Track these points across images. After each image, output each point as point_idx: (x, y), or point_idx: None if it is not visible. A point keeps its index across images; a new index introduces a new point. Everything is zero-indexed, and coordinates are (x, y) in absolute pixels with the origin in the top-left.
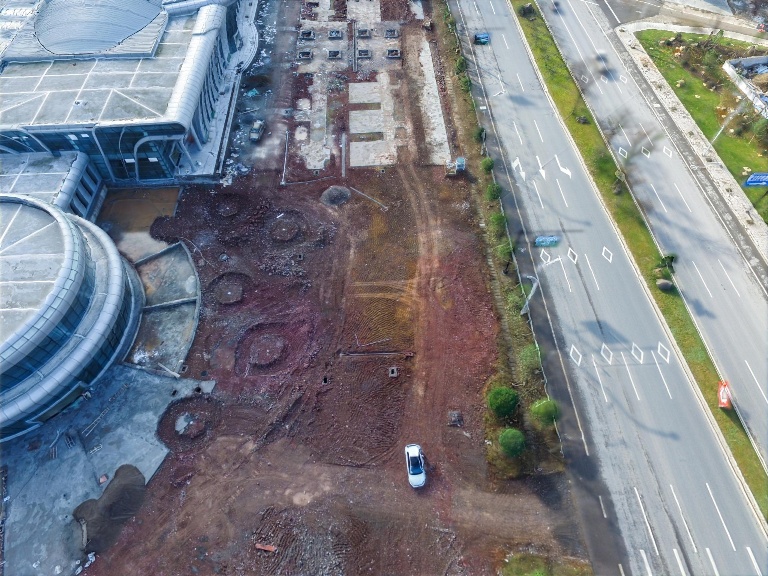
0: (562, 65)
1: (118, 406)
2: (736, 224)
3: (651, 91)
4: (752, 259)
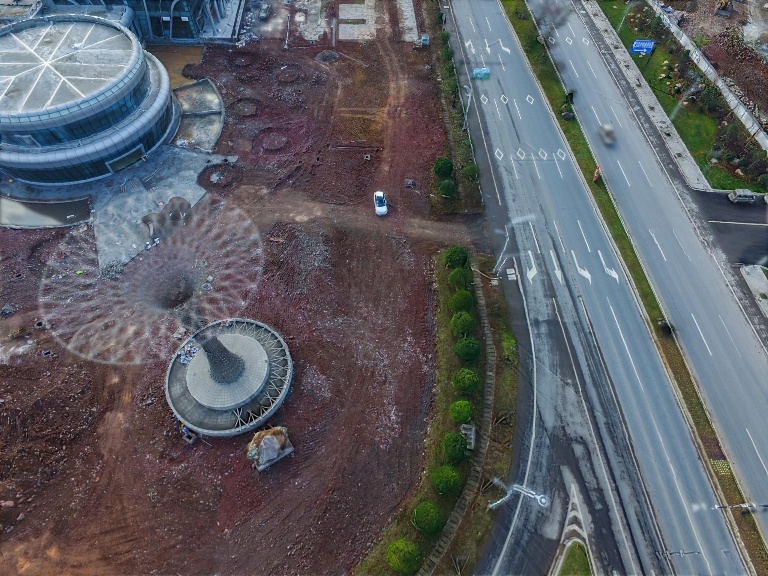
0: None
1: (168, 167)
2: (628, 86)
3: (580, 2)
4: (635, 107)
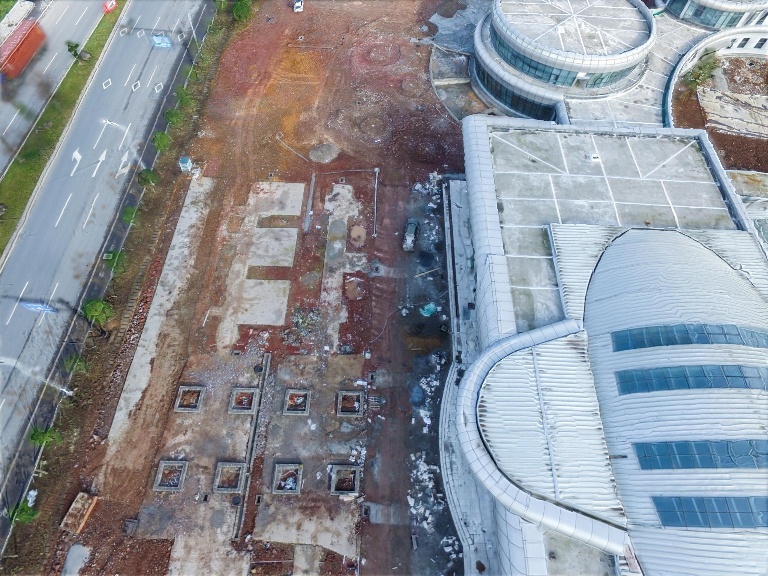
0: None
1: None
2: None
3: None
4: None
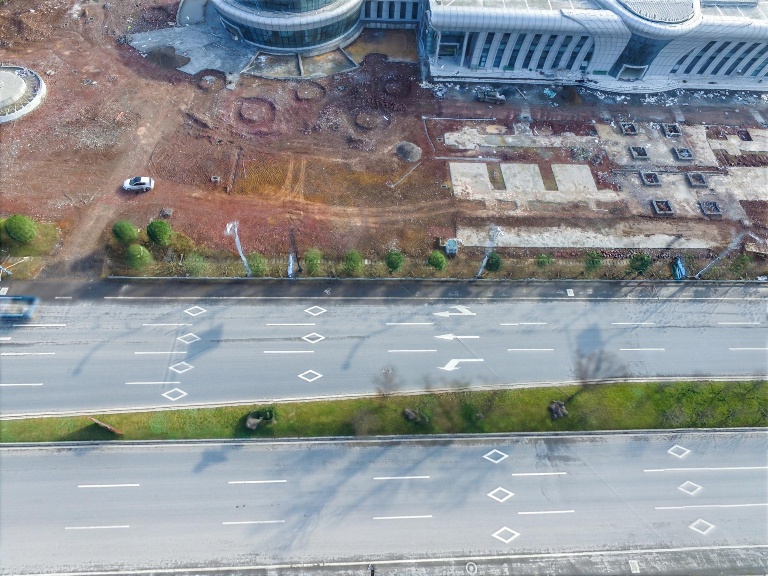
0: (702, 416)
1: (229, 53)
2: None
3: (678, 571)
4: None
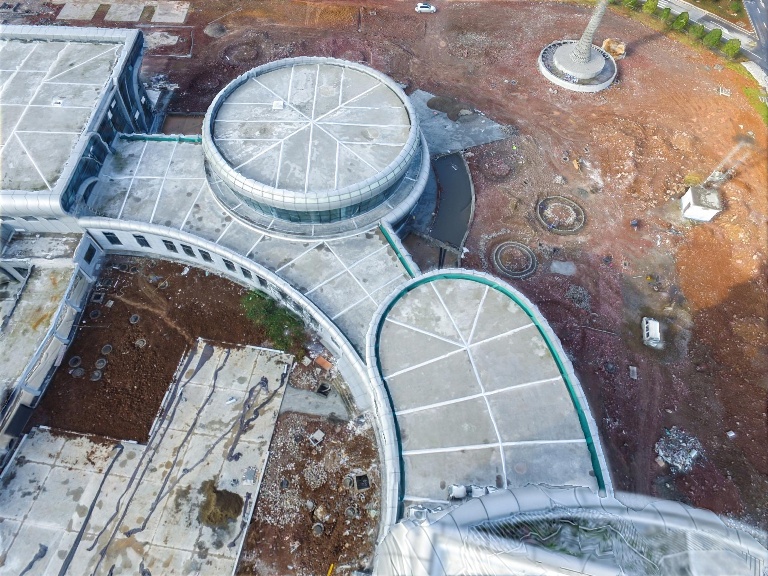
0: None
1: None
2: None
3: None
4: None
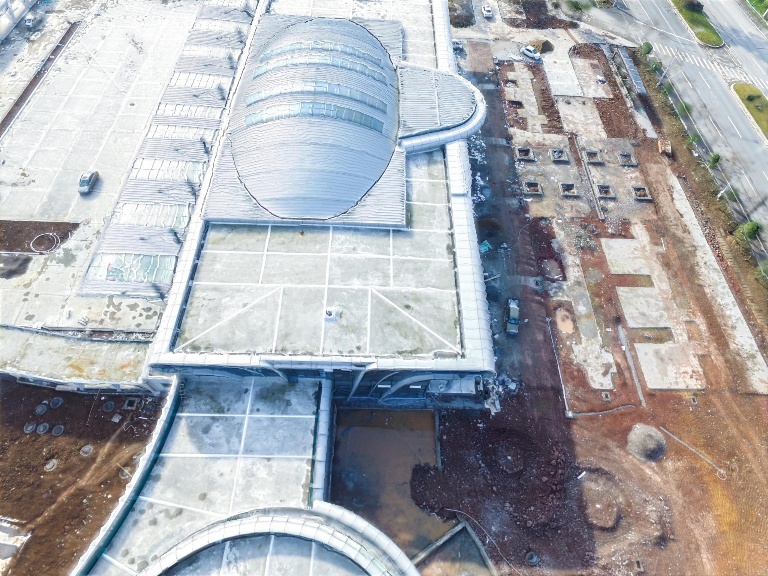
0: None
1: None
2: None
3: None
4: None
